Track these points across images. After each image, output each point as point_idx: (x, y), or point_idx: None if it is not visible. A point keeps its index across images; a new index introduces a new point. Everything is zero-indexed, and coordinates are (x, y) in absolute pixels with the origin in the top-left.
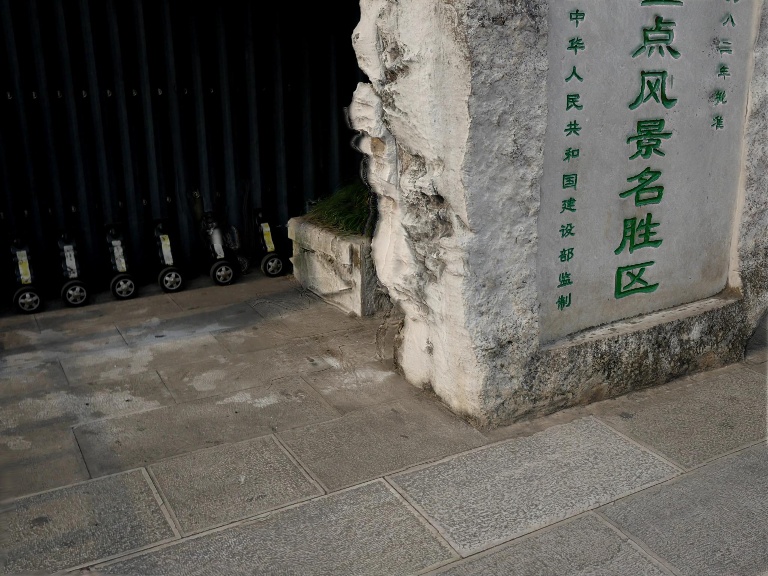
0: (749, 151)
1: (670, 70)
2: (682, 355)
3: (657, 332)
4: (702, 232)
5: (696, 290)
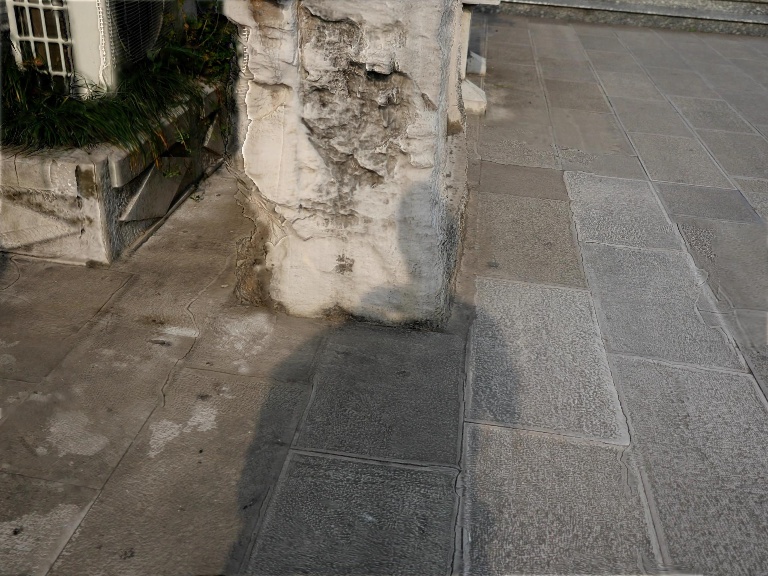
0: None
1: None
2: (467, 195)
3: None
4: None
5: None
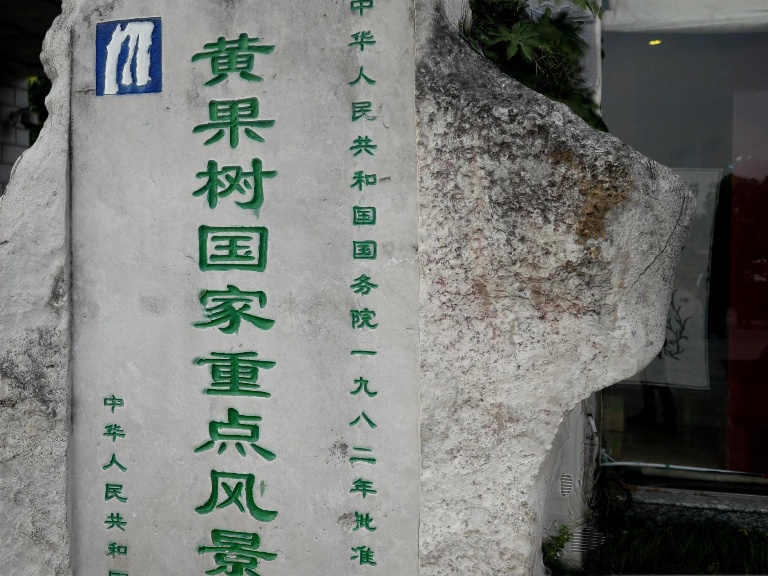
0: None
1: (258, 474)
2: None
3: None
4: None
5: None
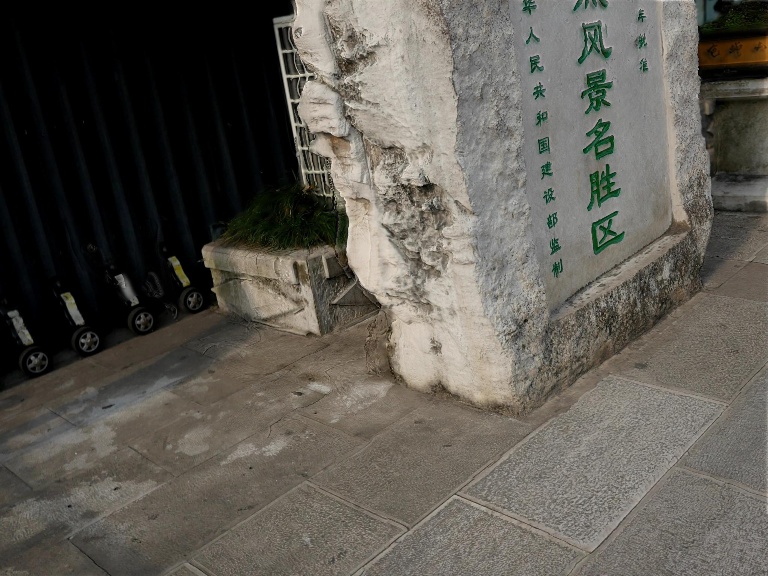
0: (671, 88)
1: (603, 19)
2: (660, 296)
3: (639, 278)
4: (647, 174)
5: (652, 231)
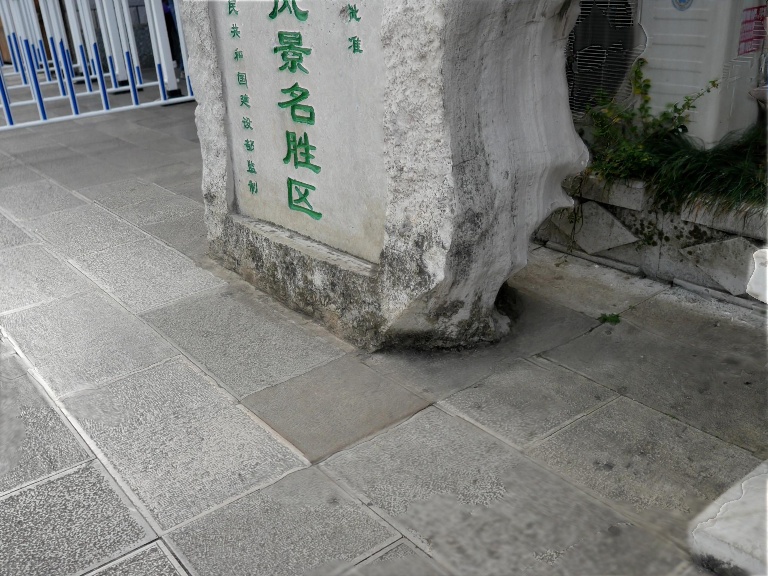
0: (386, 89)
1: None
2: (305, 292)
3: (284, 251)
4: (358, 177)
5: (360, 245)
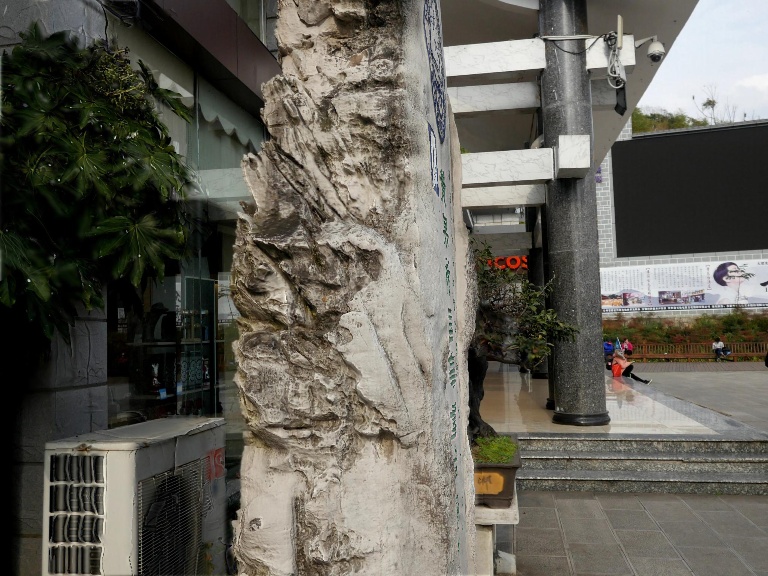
0: None
1: (458, 491)
2: None
3: None
4: None
5: None
